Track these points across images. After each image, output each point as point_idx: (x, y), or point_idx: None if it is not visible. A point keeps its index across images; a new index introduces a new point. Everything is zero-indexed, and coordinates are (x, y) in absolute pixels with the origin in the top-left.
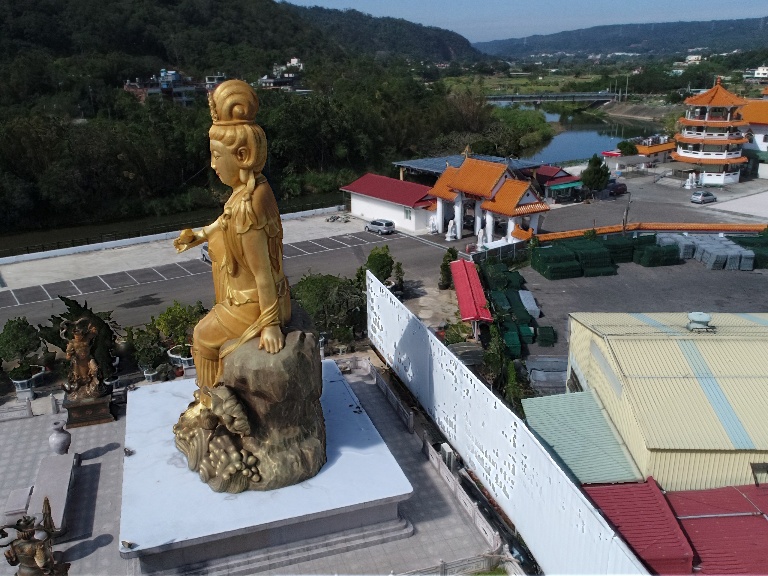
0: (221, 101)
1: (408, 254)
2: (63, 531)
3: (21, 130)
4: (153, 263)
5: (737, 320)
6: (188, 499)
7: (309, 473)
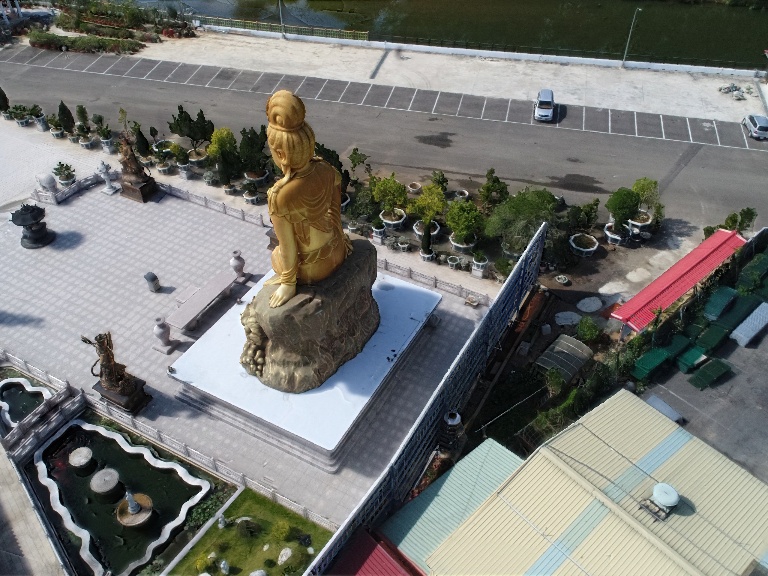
0: (270, 108)
1: (739, 181)
2: (192, 328)
3: None
4: (494, 92)
5: (759, 522)
6: (226, 359)
7: (293, 390)
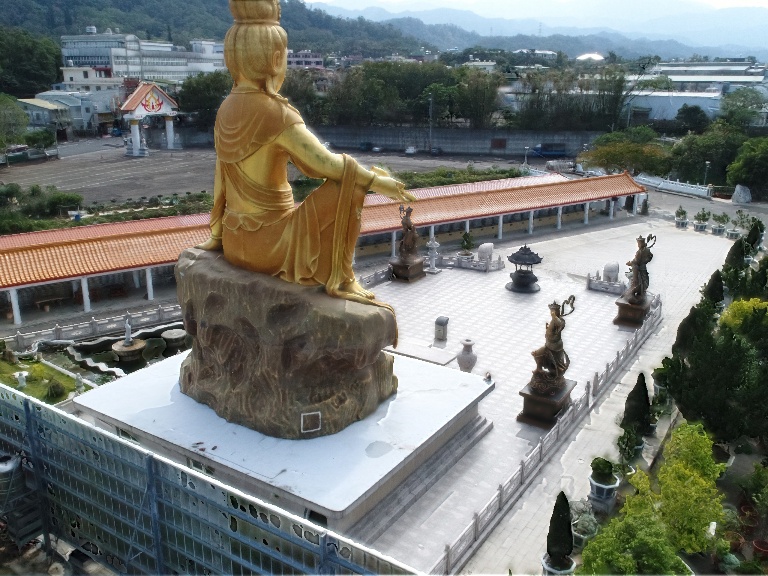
0: None
1: None
2: None
3: None
4: None
5: None
6: None
7: None
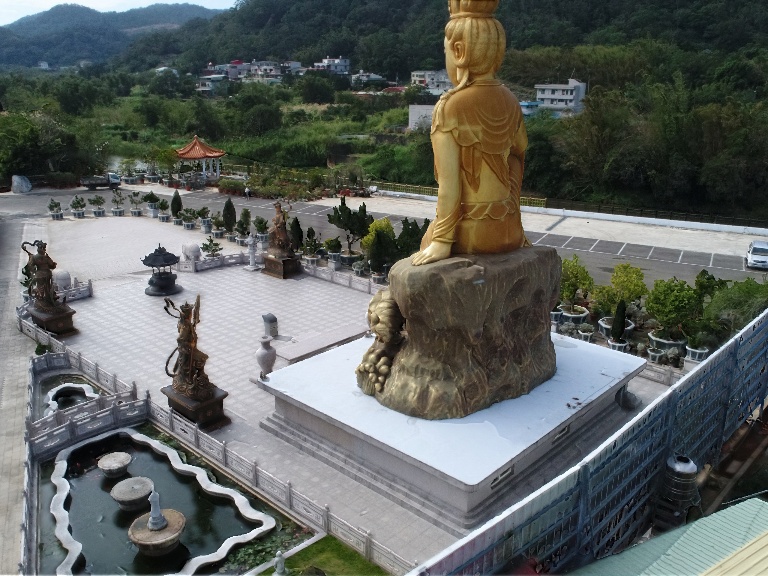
0: None
1: None
2: None
3: (706, 114)
4: (691, 247)
5: None
6: (338, 378)
7: (424, 412)
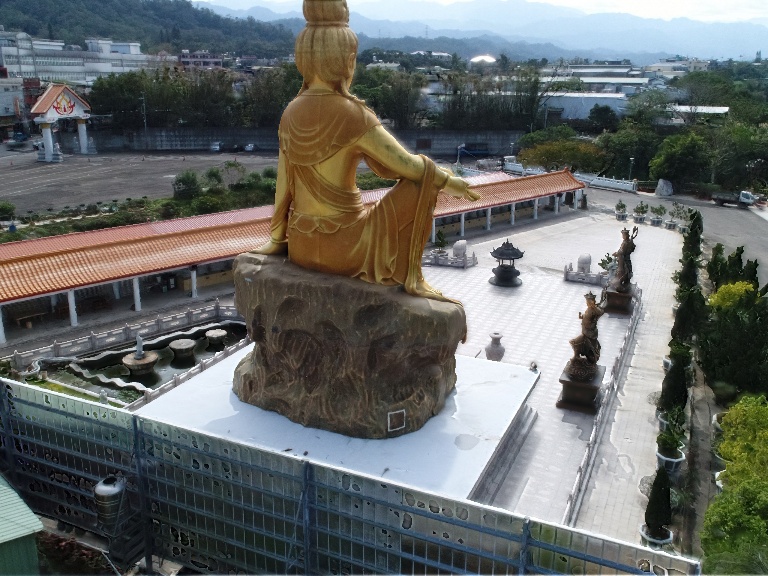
0: None
1: None
2: None
3: None
4: None
5: None
6: None
7: None
